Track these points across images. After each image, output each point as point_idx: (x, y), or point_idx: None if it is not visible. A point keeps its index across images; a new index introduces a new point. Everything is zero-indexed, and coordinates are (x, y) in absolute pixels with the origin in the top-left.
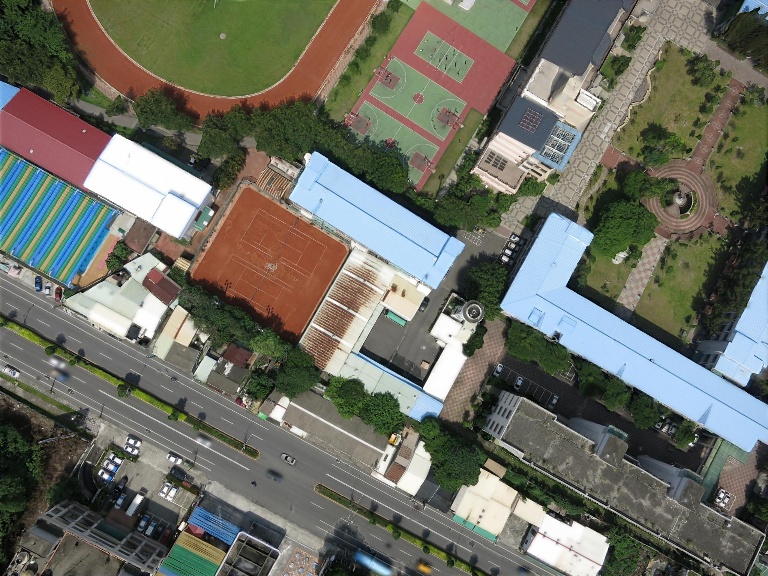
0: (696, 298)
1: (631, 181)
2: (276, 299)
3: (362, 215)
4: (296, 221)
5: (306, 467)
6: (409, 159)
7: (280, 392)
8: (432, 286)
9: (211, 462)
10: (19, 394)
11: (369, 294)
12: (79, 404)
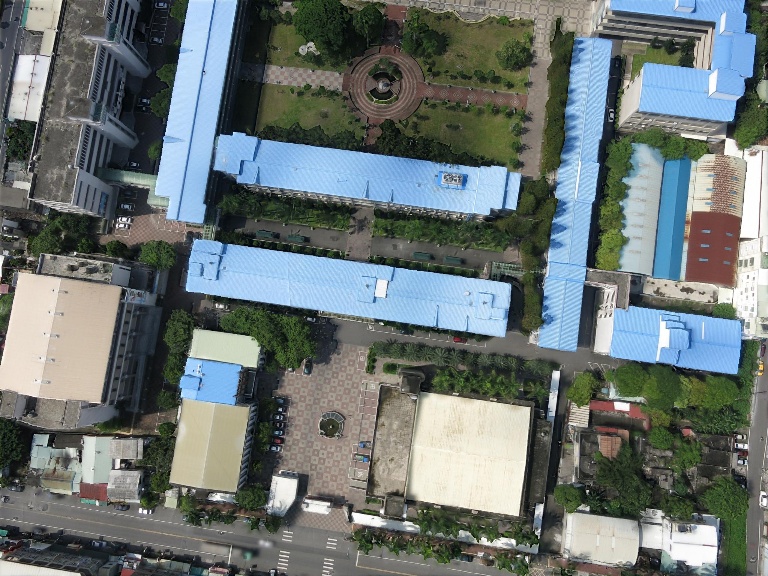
0: None
1: (366, 8)
2: None
3: None
4: None
5: None
6: None
7: None
8: None
9: None
10: None
11: None
12: None
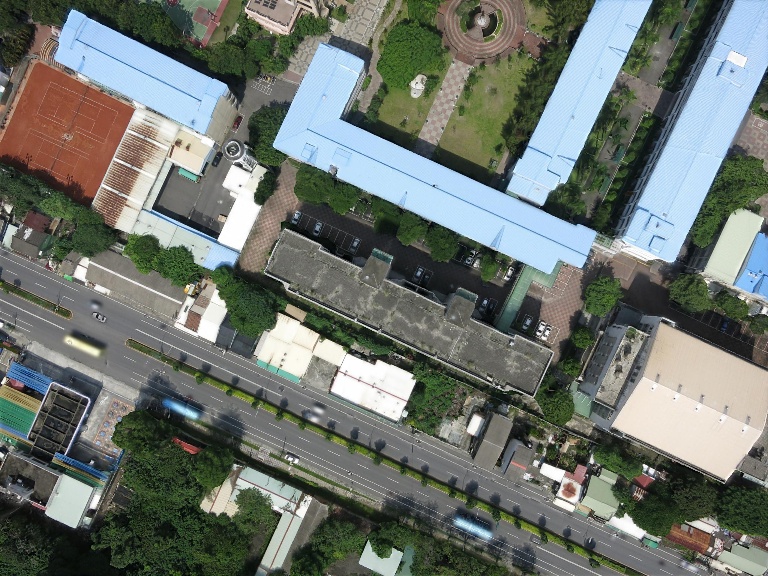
0: (507, 125)
1: (411, 2)
2: (74, 167)
3: (123, 67)
4: (86, 90)
5: (116, 324)
6: (192, 15)
7: (77, 252)
8: (200, 131)
9: (30, 324)
10: None
11: (152, 150)
12: None
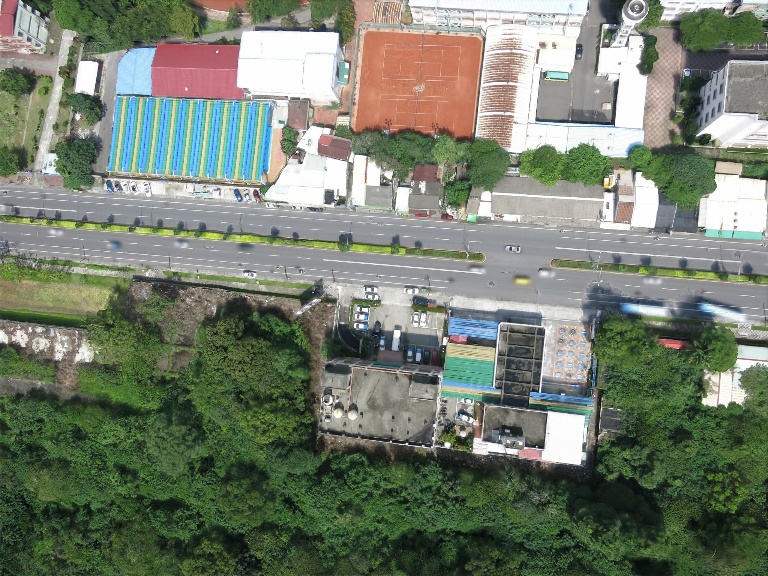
0: None
1: None
2: (436, 114)
3: None
4: (422, 38)
5: (533, 249)
6: None
7: (478, 187)
8: (581, 13)
9: (444, 281)
10: (263, 290)
11: (521, 60)
12: (313, 278)
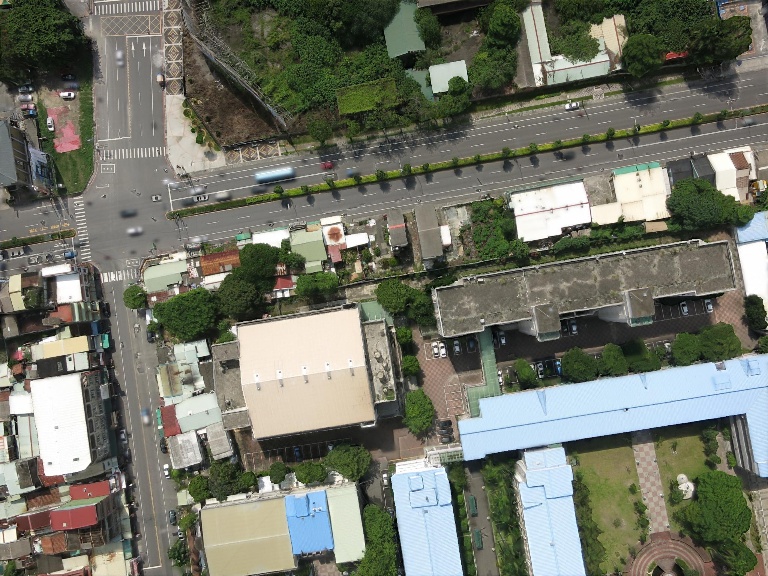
0: None
1: (752, 555)
2: None
3: None
4: None
5: None
6: None
7: None
8: None
9: None
10: None
11: None
12: None
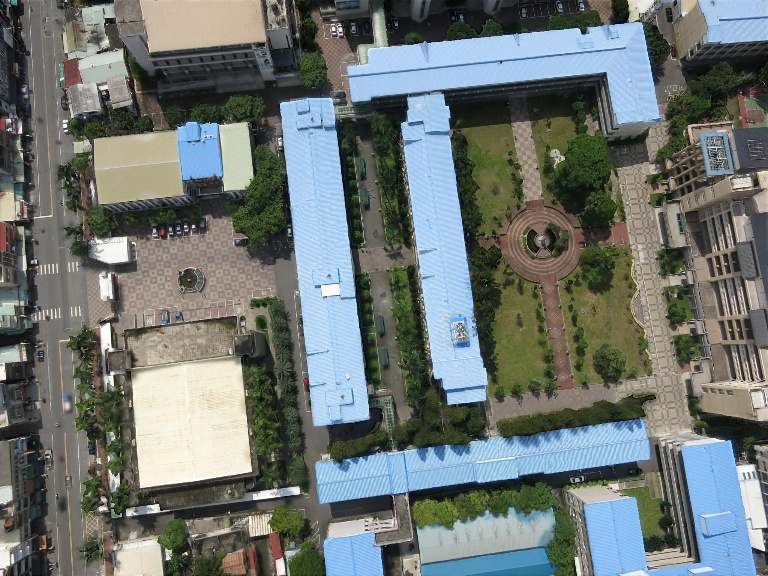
0: None
1: (612, 202)
2: None
3: None
4: None
5: None
6: (765, 113)
7: None
8: (703, 0)
9: None
10: None
11: None
12: None
